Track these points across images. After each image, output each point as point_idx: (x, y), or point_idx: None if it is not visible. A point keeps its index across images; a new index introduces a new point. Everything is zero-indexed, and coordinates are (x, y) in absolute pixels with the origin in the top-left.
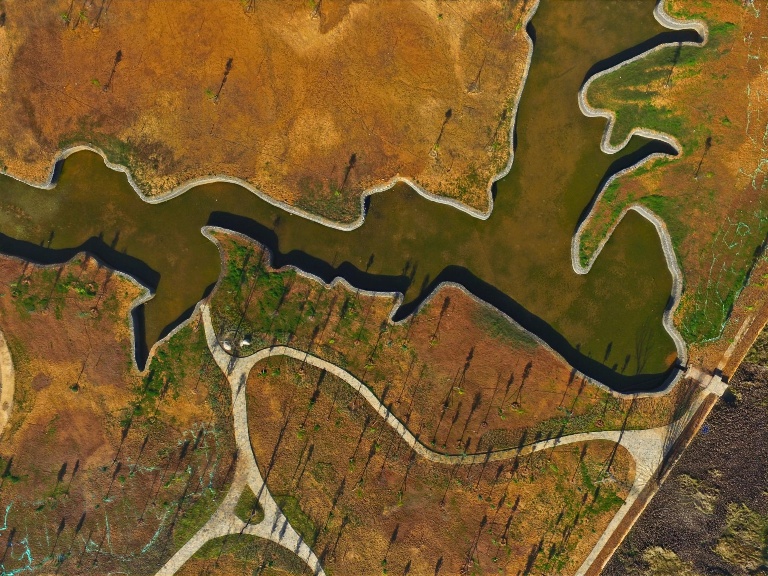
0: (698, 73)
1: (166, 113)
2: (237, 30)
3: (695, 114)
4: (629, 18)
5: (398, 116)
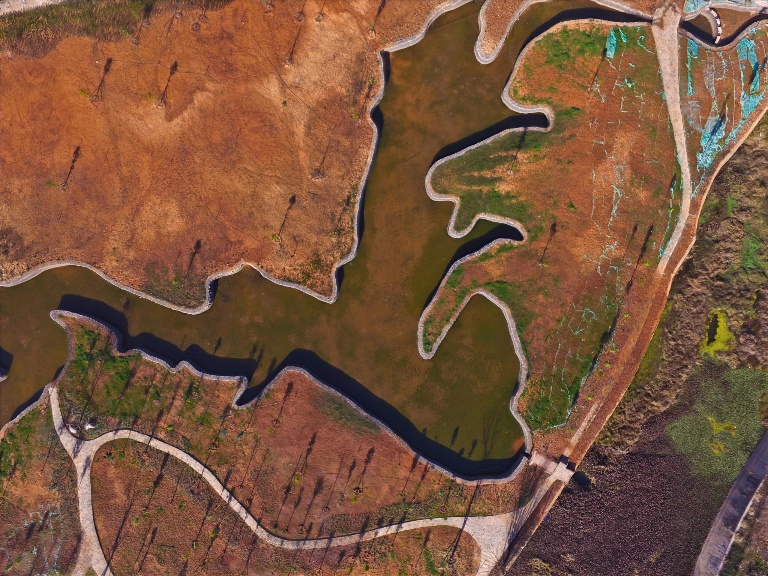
0: (543, 158)
1: (16, 200)
2: (84, 119)
3: (540, 200)
4: (477, 102)
5: (242, 202)
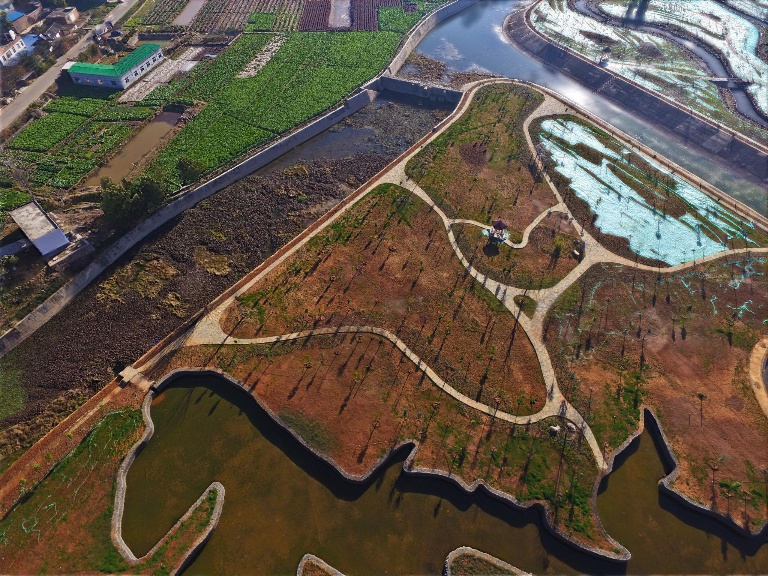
0: None
1: None
2: None
3: None
4: None
5: None
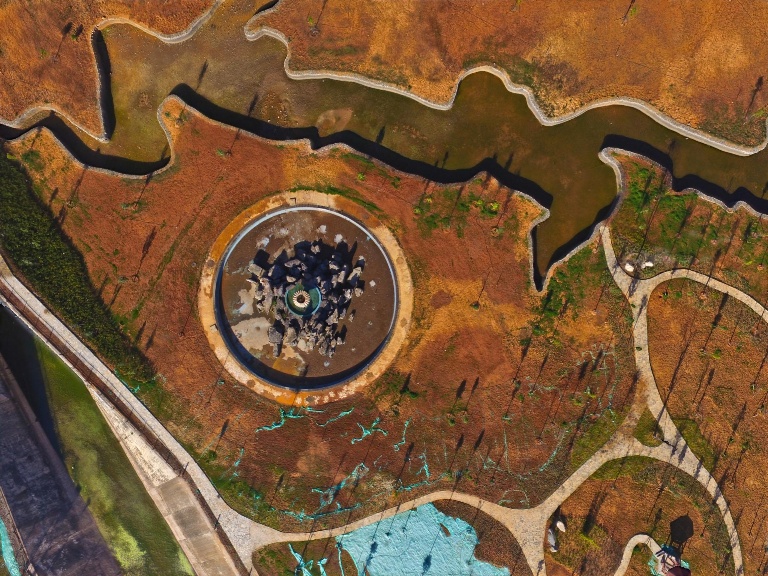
0: None
1: (572, 34)
2: None
3: None
4: None
5: None
